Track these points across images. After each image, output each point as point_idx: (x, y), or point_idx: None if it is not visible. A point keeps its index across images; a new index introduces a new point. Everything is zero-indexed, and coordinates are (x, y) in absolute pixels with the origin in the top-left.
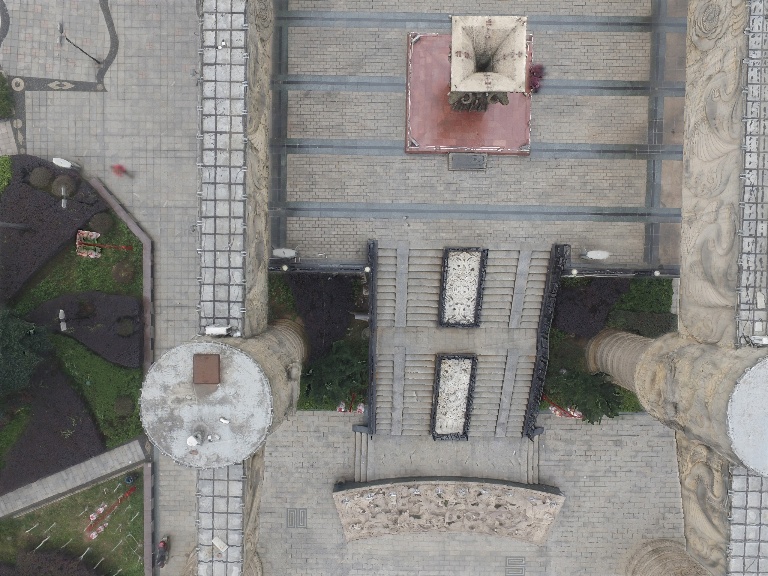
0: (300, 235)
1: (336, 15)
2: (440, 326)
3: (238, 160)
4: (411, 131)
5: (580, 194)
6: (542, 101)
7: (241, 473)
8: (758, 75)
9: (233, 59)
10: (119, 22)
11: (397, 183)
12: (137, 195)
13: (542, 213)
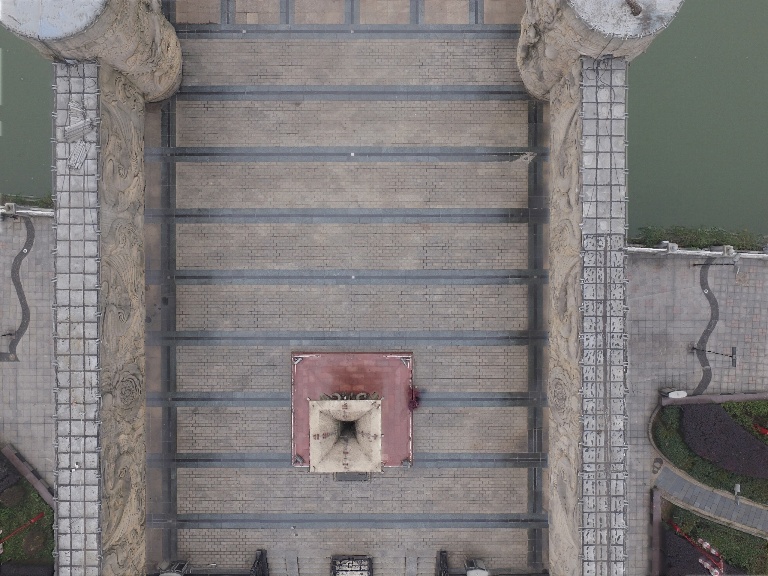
0: (190, 546)
1: (222, 334)
2: None
3: (93, 575)
4: (296, 447)
5: (463, 502)
6: (424, 413)
7: None
8: (593, 487)
9: (87, 480)
10: (30, 295)
11: (284, 494)
12: (49, 460)
13: (426, 521)
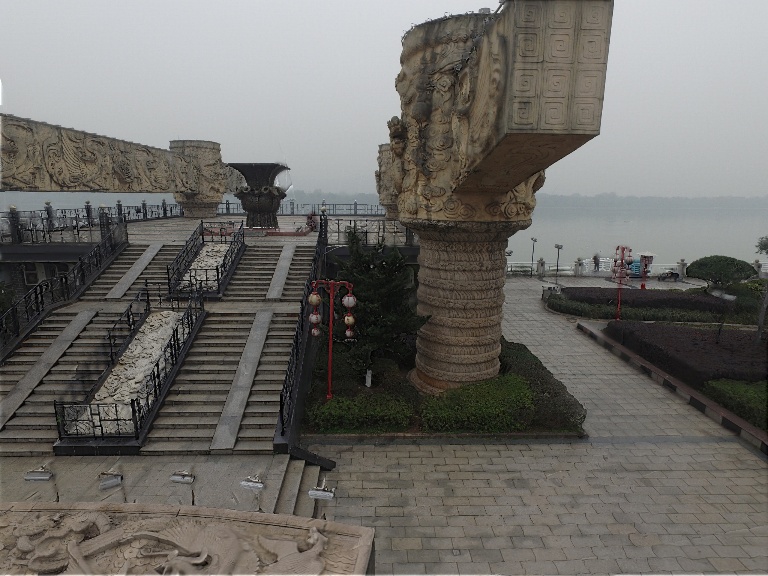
0: None
1: None
2: (169, 296)
3: None
4: None
5: None
6: None
7: None
8: None
9: None
10: None
11: None
12: None
13: None
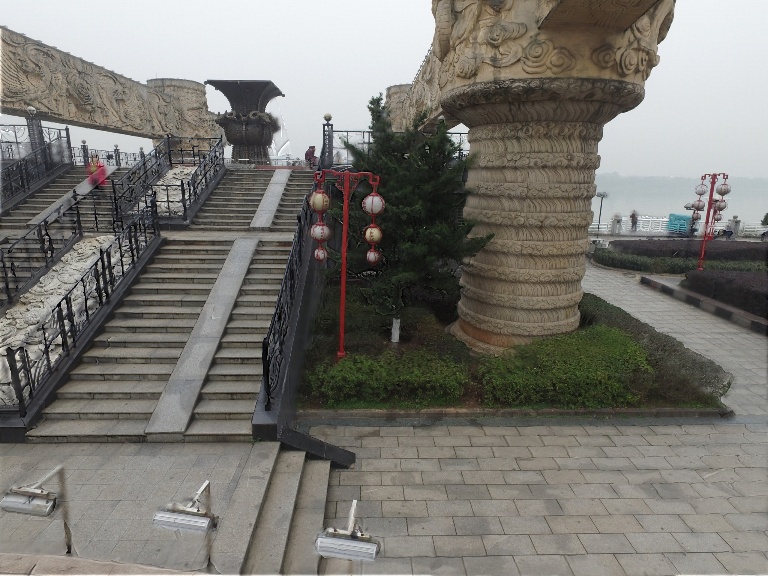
0: None
1: None
2: None
3: None
4: None
5: None
6: None
7: None
8: None
9: None
10: None
11: None
12: None
13: None
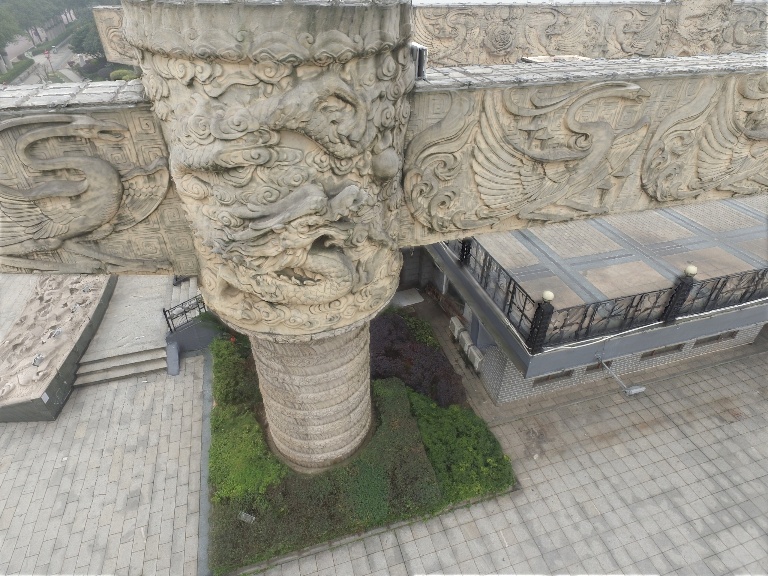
0: None
1: None
2: None
3: None
4: None
5: None
6: None
7: None
8: None
9: None
10: None
11: None
12: None
13: None
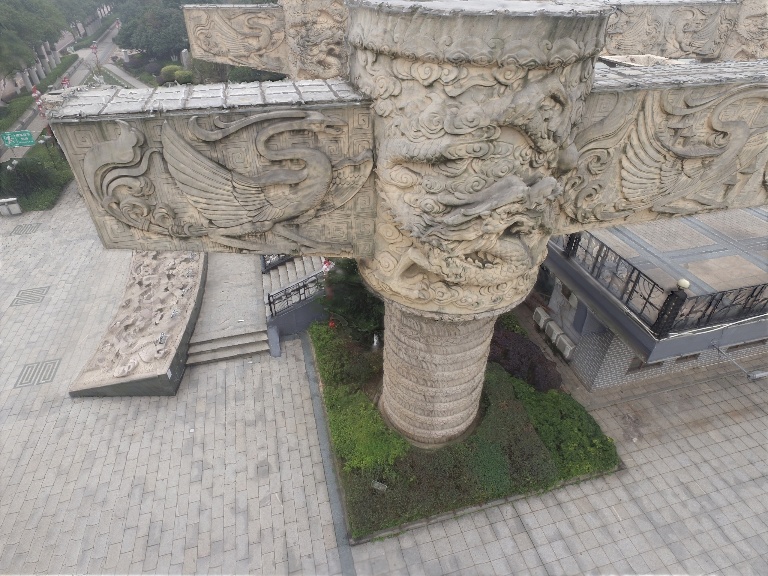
0: None
1: None
2: None
3: None
4: None
5: None
6: None
7: (264, 6)
8: None
9: None
10: None
11: None
12: None
13: None
